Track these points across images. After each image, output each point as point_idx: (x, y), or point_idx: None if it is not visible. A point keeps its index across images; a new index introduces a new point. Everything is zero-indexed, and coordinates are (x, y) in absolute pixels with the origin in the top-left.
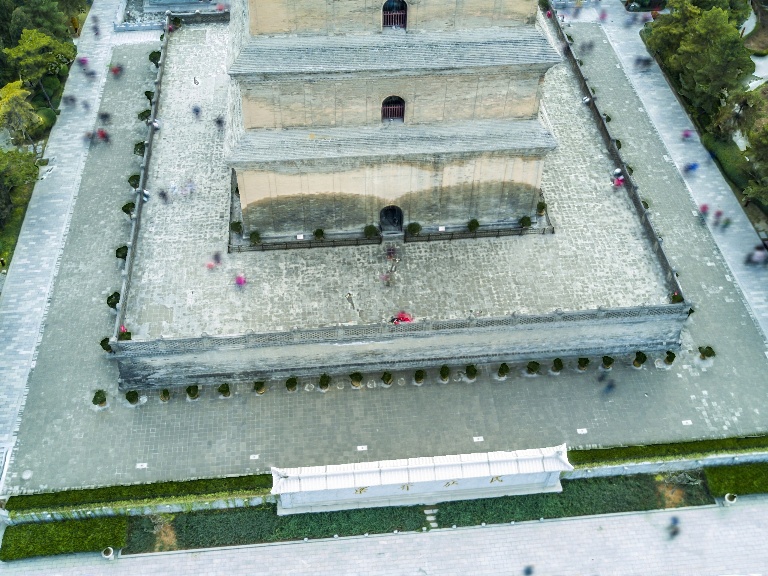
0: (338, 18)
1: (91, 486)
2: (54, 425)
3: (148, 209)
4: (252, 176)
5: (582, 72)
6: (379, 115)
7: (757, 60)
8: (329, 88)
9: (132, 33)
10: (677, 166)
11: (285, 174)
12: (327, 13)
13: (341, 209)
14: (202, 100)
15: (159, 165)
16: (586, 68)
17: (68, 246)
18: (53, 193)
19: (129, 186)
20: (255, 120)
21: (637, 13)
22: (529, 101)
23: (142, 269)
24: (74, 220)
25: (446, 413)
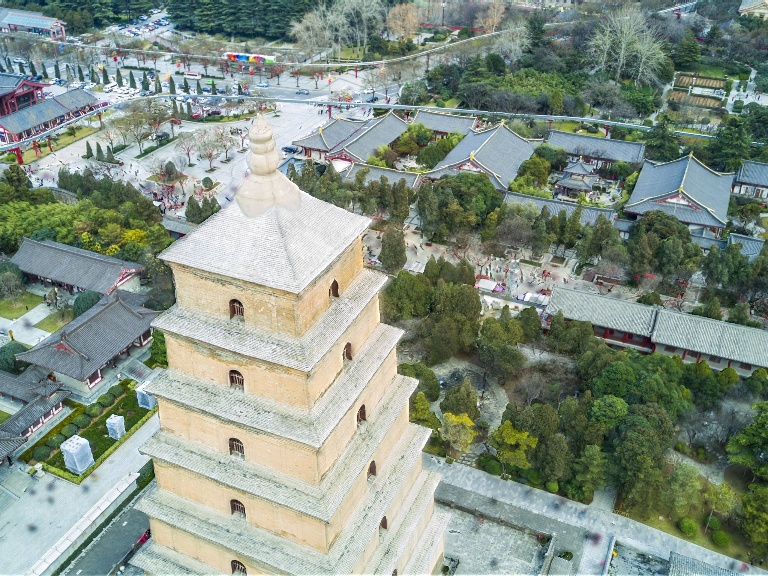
0: None
1: None
2: None
3: None
4: None
5: None
6: None
7: None
8: None
9: (604, 546)
10: None
11: None
12: None
13: None
14: None
15: None
16: None
17: None
18: None
19: None
20: None
21: None
22: None
23: None
24: None
25: (105, 566)
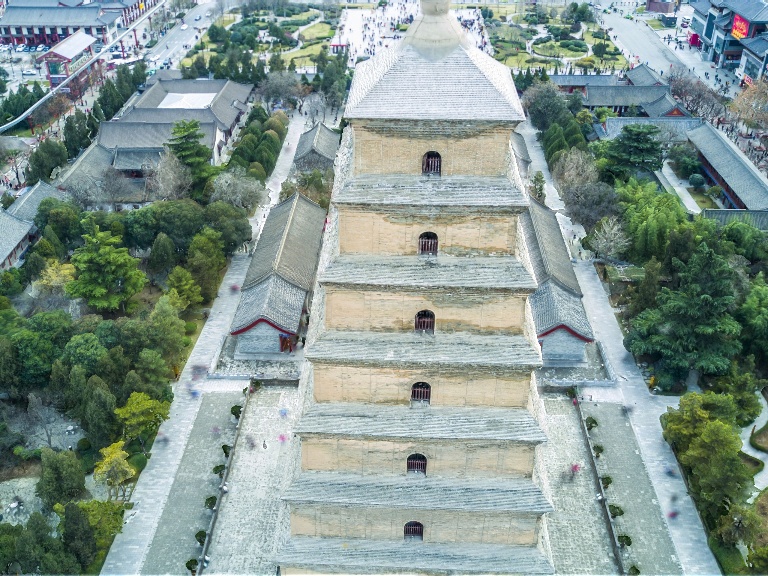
0: (371, 463)
1: None
2: None
3: (206, 575)
4: (293, 571)
5: (597, 469)
6: (402, 534)
7: (767, 458)
8: (361, 512)
9: (221, 381)
10: (683, 568)
11: (321, 572)
12: (363, 460)
13: None
14: (267, 465)
15: (222, 529)
16: (608, 452)
17: None
18: (132, 539)
19: (195, 539)
20: (300, 529)
21: (659, 397)
22: (529, 534)
23: None
24: (145, 569)
25: None
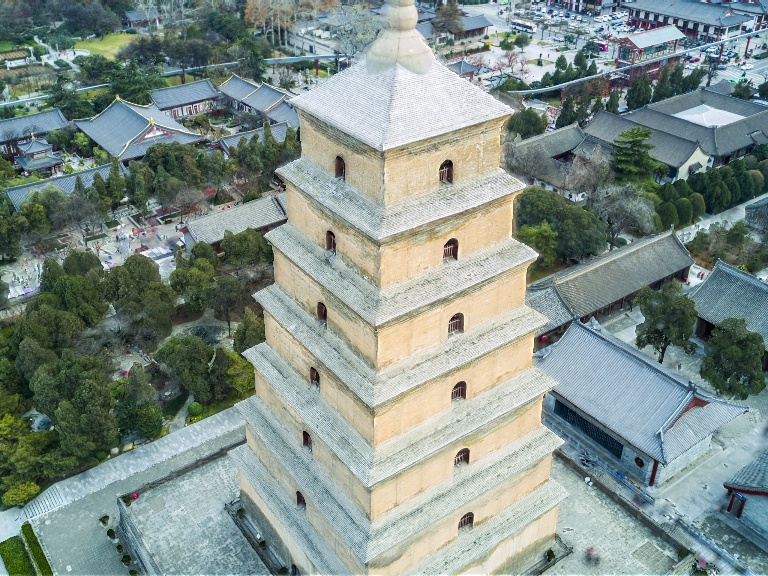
0: None
1: (49, 554)
2: (84, 513)
3: None
4: None
5: None
6: (296, 498)
7: None
8: None
9: None
10: None
11: None
12: None
13: (276, 540)
14: None
15: None
16: None
17: (220, 438)
18: None
19: None
20: None
21: None
22: (362, 575)
23: (191, 477)
24: (243, 427)
25: None
